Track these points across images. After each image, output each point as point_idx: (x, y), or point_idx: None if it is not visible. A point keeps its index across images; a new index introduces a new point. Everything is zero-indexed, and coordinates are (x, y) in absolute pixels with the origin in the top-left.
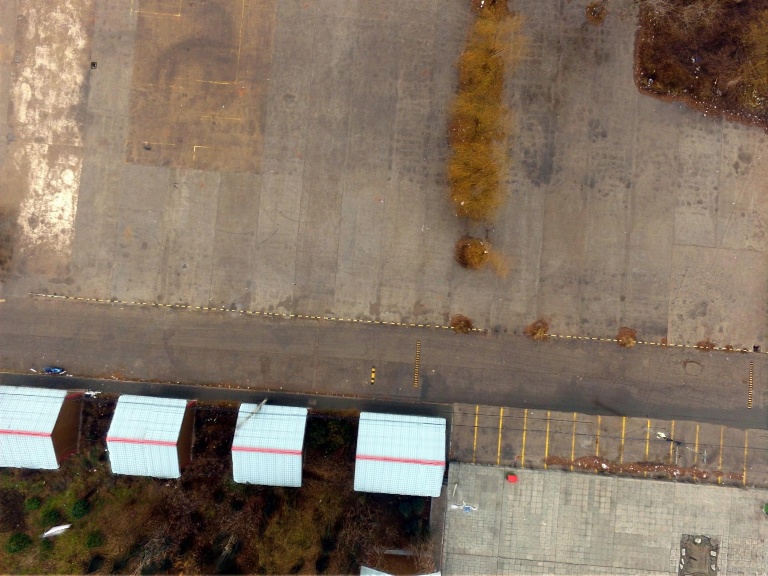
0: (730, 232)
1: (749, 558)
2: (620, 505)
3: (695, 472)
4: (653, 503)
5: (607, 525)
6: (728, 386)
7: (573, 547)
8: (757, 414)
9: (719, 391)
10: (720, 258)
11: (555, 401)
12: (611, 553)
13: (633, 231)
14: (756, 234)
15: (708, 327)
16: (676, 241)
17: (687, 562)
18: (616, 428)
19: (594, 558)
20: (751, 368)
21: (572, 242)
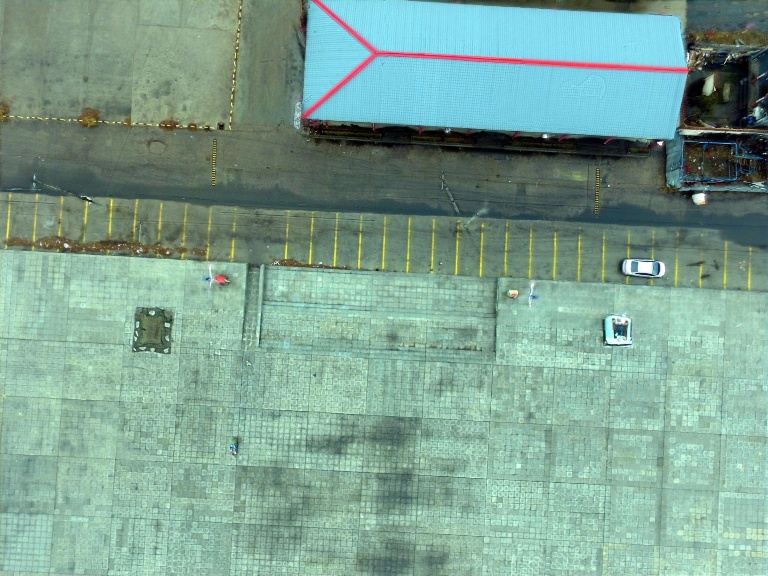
0: (195, 12)
1: (203, 328)
2: (74, 280)
3: (158, 249)
4: (107, 277)
5: (61, 300)
6: (191, 163)
7: (26, 323)
8: (222, 191)
9: (182, 169)
10: (184, 37)
11: (17, 183)
12: (65, 328)
13: (97, 12)
14: (221, 13)
15: (172, 106)
16: (140, 21)
17: (141, 334)
18: (79, 208)
19: (48, 333)
20: (214, 145)
21: (34, 24)
